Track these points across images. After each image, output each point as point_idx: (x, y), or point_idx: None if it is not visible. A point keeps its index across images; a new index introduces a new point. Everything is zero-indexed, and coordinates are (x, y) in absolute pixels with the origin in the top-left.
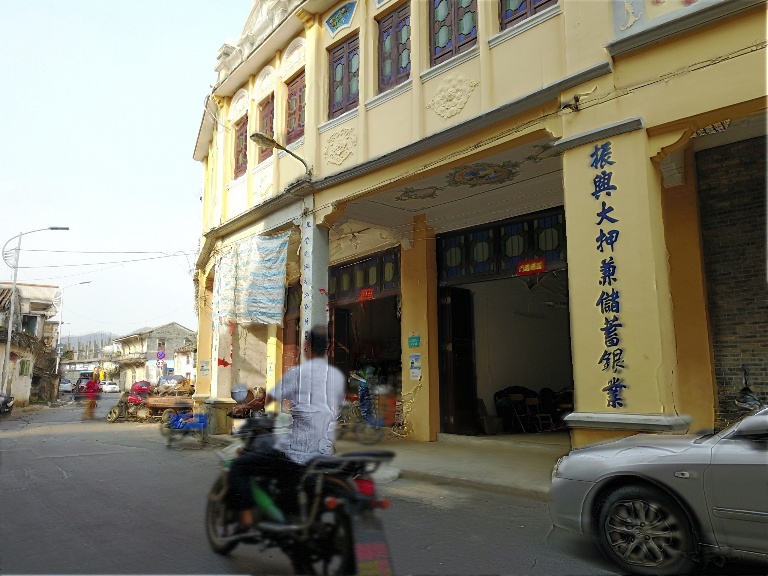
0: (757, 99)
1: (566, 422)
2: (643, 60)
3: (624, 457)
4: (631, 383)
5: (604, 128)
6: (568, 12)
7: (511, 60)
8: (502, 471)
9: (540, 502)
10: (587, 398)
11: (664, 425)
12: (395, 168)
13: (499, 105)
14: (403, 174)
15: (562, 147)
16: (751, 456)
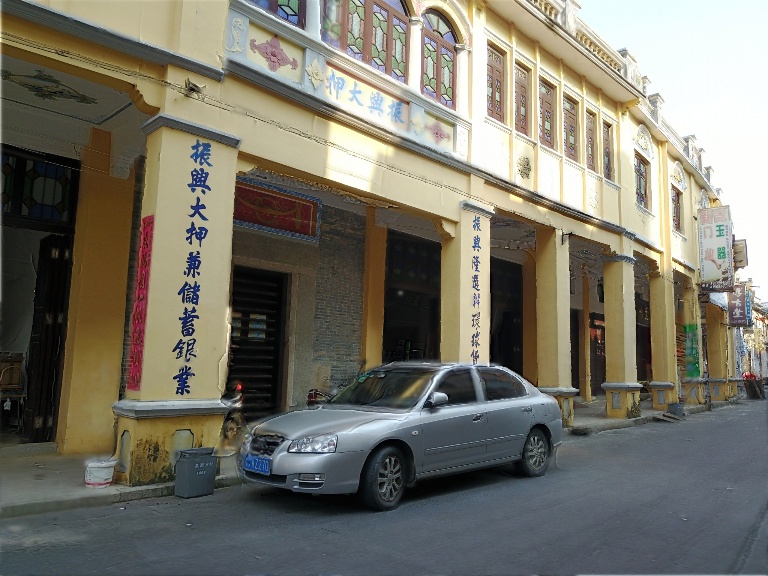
0: (301, 171)
1: (139, 412)
2: (242, 90)
3: (381, 428)
4: (200, 371)
5: (211, 130)
6: None
7: None
8: None
9: (106, 507)
10: (157, 386)
11: (225, 408)
12: None
13: (75, 15)
14: None
15: (165, 122)
16: (433, 417)
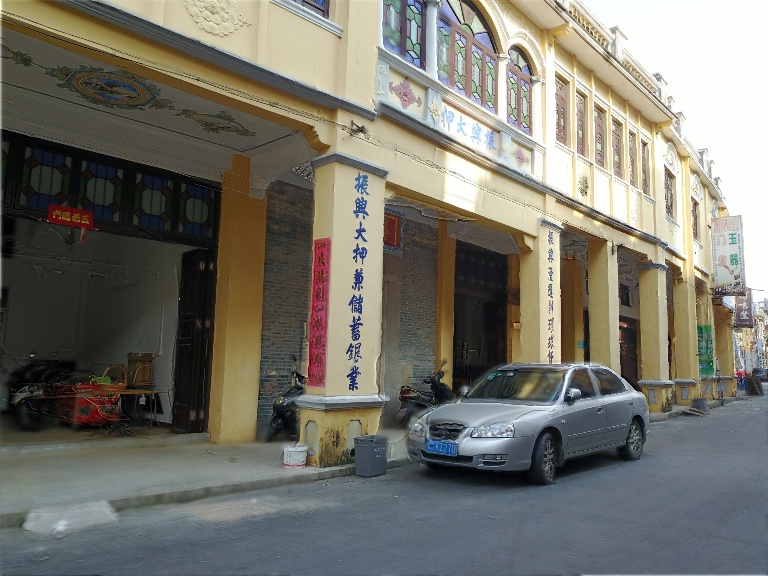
0: (427, 196)
1: (328, 405)
2: None
3: (541, 417)
4: (364, 371)
5: (370, 164)
6: (352, 45)
7: (289, 34)
8: (183, 473)
9: (312, 484)
10: (337, 383)
11: None
12: (107, 32)
13: (272, 69)
14: (143, 59)
15: (338, 158)
16: (570, 409)
